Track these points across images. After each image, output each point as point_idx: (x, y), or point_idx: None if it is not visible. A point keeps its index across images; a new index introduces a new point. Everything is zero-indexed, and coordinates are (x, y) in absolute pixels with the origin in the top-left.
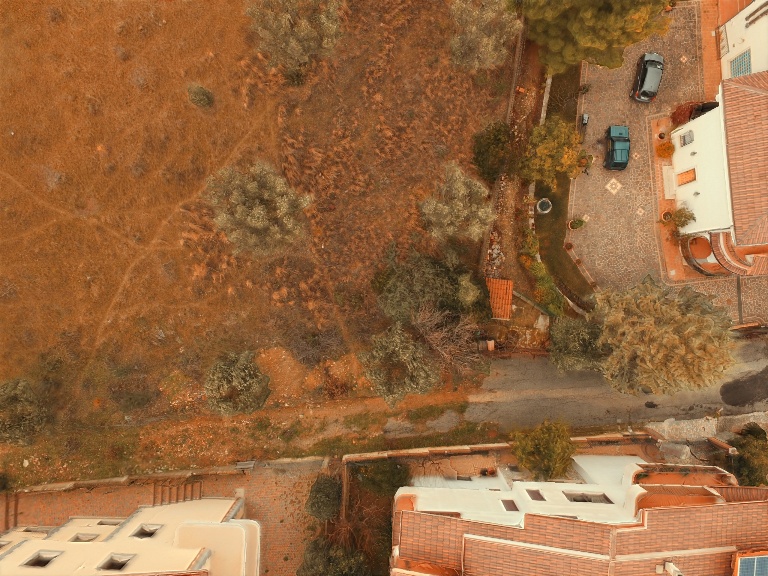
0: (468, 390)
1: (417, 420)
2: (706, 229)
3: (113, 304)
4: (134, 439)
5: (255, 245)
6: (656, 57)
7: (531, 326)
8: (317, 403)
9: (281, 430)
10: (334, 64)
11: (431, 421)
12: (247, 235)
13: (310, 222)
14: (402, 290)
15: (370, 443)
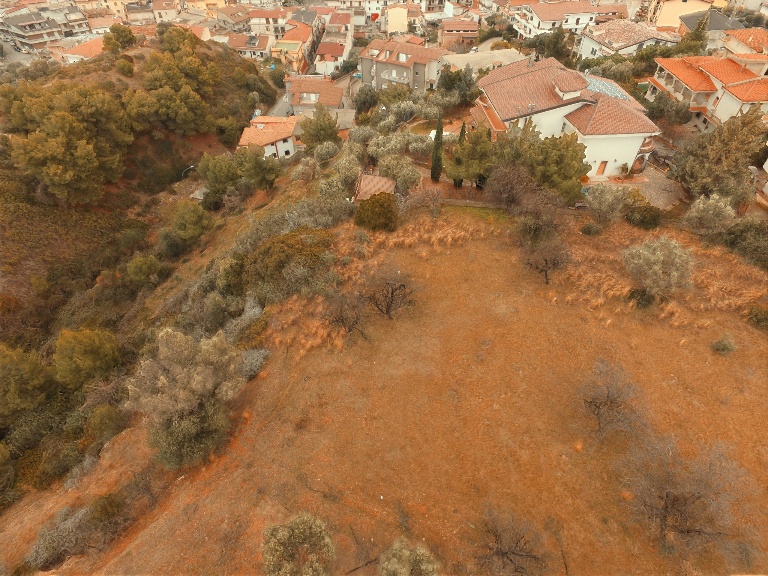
0: None
1: None
2: (636, 156)
3: None
4: None
5: None
6: None
7: None
8: None
9: None
10: None
11: None
12: None
13: (762, 296)
14: None
15: None
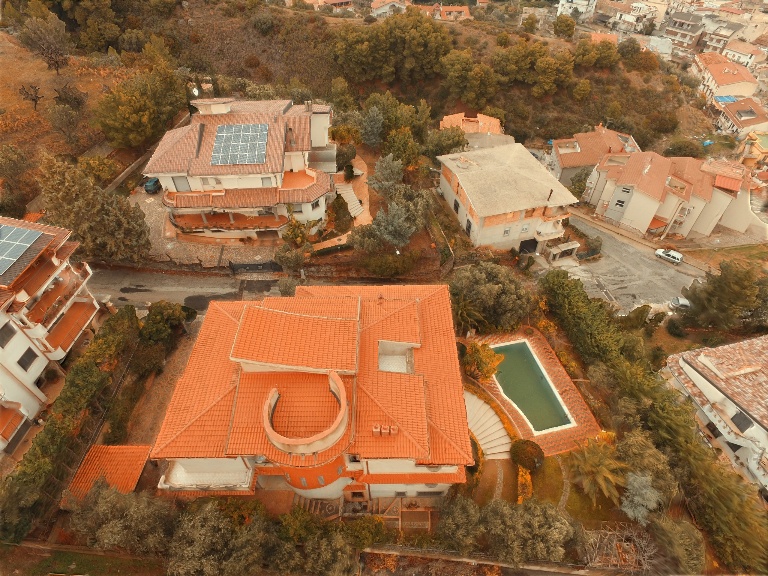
0: None
1: None
2: None
3: None
4: None
5: None
6: None
7: None
8: None
9: None
10: (3, 137)
11: None
12: None
13: None
14: None
15: None
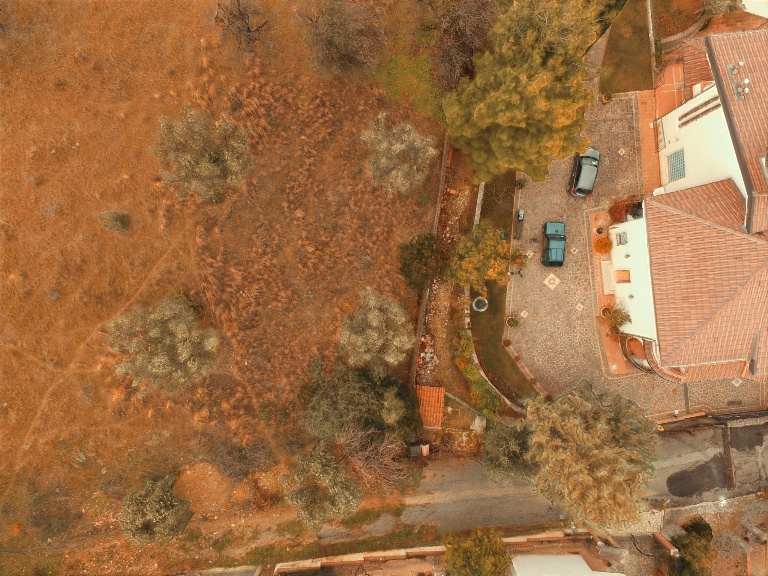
0: (405, 493)
1: (353, 525)
2: (640, 335)
3: (32, 428)
4: (59, 558)
5: (161, 387)
6: (592, 153)
7: (467, 428)
8: (249, 512)
9: (213, 540)
10: (253, 180)
11: (367, 525)
12: (150, 380)
13: (232, 340)
14: (326, 409)
15: (304, 550)
